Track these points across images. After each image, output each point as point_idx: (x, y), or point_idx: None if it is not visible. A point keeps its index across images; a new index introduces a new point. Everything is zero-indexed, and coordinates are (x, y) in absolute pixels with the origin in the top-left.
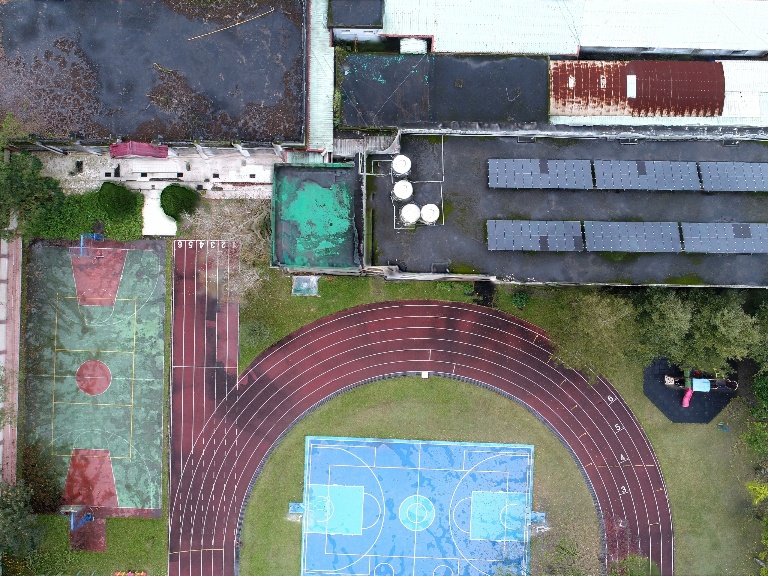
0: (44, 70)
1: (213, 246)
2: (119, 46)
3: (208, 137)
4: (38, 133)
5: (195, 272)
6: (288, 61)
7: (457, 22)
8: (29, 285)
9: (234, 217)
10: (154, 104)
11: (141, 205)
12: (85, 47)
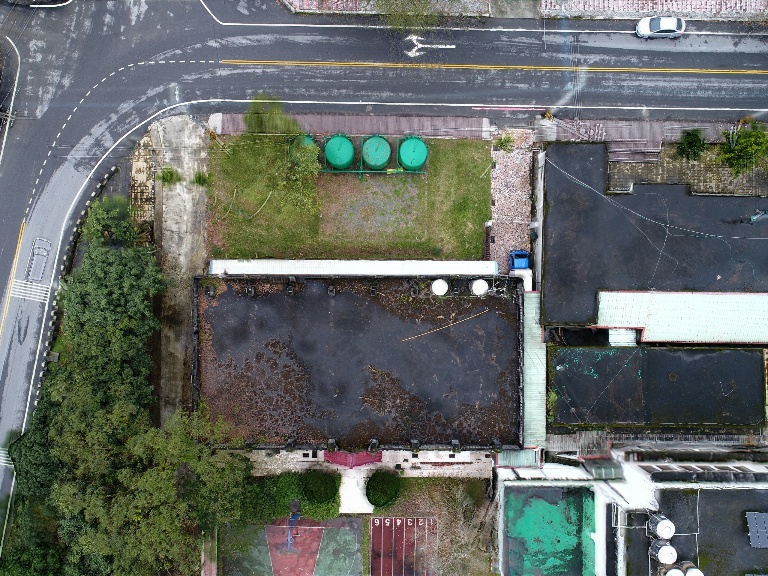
0: (255, 372)
1: (410, 523)
2: (331, 347)
3: (422, 439)
4: (250, 436)
5: (392, 550)
6: (503, 361)
7: (670, 315)
8: (224, 564)
9: (432, 495)
10: (367, 406)
11: (338, 484)
12: (297, 349)
